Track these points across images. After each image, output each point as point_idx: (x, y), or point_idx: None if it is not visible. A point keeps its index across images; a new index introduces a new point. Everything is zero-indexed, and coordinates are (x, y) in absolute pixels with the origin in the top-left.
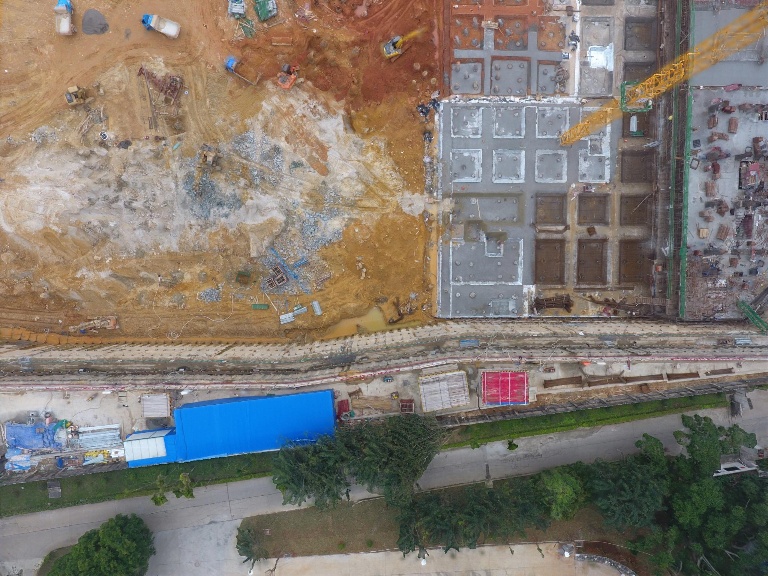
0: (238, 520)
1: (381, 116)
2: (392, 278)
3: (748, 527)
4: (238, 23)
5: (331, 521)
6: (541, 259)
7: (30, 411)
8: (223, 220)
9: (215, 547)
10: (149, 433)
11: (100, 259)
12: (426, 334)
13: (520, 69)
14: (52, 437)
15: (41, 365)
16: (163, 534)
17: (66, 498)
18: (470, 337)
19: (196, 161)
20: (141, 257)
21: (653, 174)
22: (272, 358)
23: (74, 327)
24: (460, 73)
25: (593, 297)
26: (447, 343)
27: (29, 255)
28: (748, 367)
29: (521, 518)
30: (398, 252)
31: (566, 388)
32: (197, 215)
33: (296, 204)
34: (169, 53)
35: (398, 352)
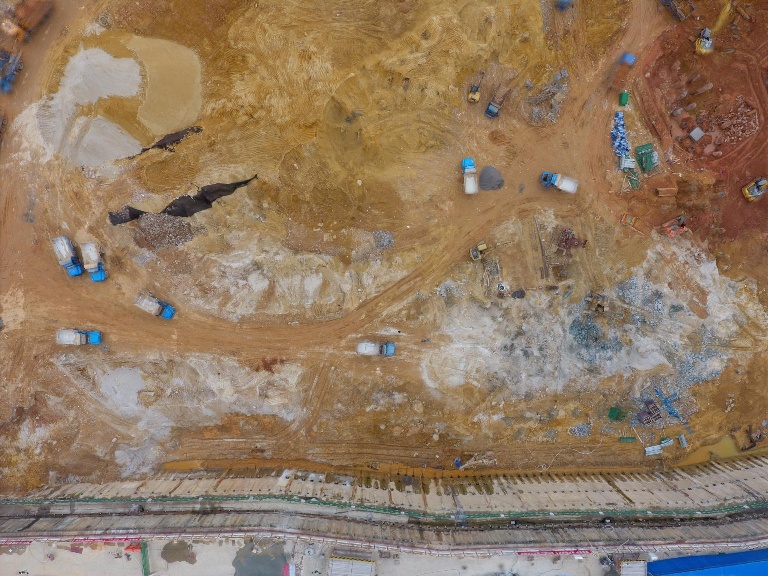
0: None
1: (735, 252)
2: (755, 411)
3: None
4: (625, 176)
5: None
6: None
7: (497, 573)
8: (609, 363)
9: None
10: None
11: (495, 404)
12: None
13: None
14: None
15: (474, 518)
16: None
17: None
18: None
19: (581, 307)
20: (530, 400)
21: None
22: (690, 507)
23: (463, 466)
24: None
25: None
26: None
27: (435, 404)
28: None
29: None
30: (762, 386)
31: None
32: (584, 359)
33: (678, 347)
34: (559, 205)
35: None
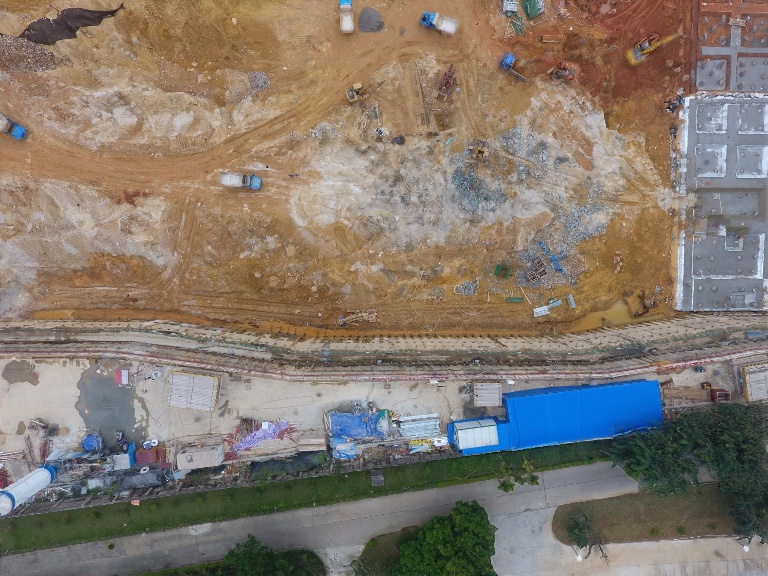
0: (553, 508)
1: (629, 112)
2: (645, 272)
3: None
4: (509, 21)
5: (643, 509)
6: None
7: (352, 401)
8: (491, 214)
9: (530, 534)
10: (473, 422)
11: (373, 253)
12: (704, 326)
13: (764, 66)
14: (374, 426)
15: (340, 356)
16: None
17: (388, 486)
18: (756, 329)
19: (464, 156)
20: (410, 251)
21: None
22: (563, 349)
23: (342, 320)
24: (705, 70)
25: None
26: (733, 335)
27: (309, 249)
28: None
29: None
30: (652, 246)
31: None
32: (466, 210)
33: (562, 199)
34: (441, 50)
35: (685, 343)
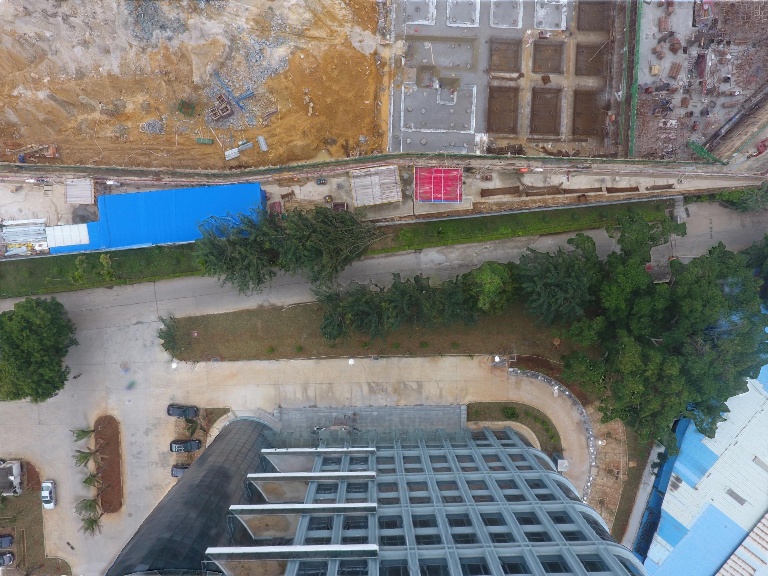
0: None
1: None
2: (340, 115)
3: (673, 310)
4: None
5: (260, 325)
6: (494, 108)
7: None
8: None
9: (141, 348)
10: None
11: (38, 78)
12: None
13: None
14: None
15: None
16: (88, 333)
17: None
18: (411, 156)
19: None
20: (81, 79)
21: (610, 22)
22: (208, 171)
23: (11, 150)
24: None
25: (546, 148)
26: None
27: None
28: (689, 184)
29: (447, 306)
30: (347, 88)
31: (503, 198)
32: (139, 37)
33: (241, 29)
34: None
35: None
